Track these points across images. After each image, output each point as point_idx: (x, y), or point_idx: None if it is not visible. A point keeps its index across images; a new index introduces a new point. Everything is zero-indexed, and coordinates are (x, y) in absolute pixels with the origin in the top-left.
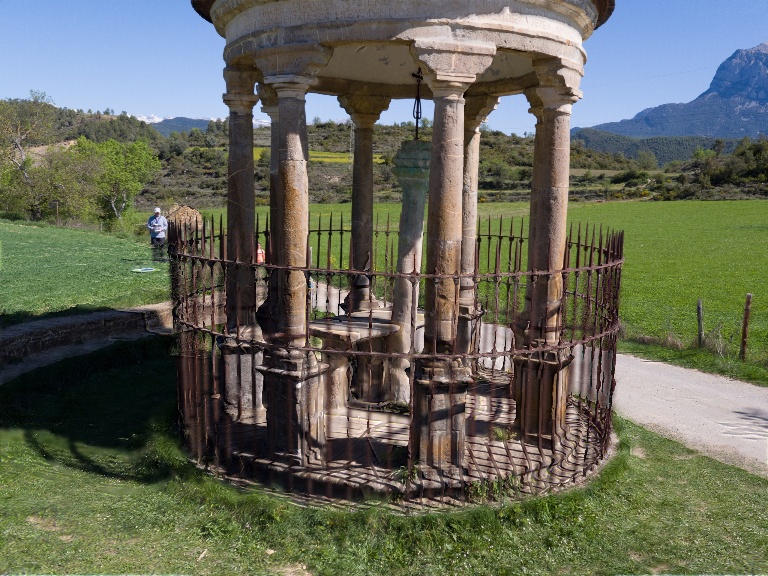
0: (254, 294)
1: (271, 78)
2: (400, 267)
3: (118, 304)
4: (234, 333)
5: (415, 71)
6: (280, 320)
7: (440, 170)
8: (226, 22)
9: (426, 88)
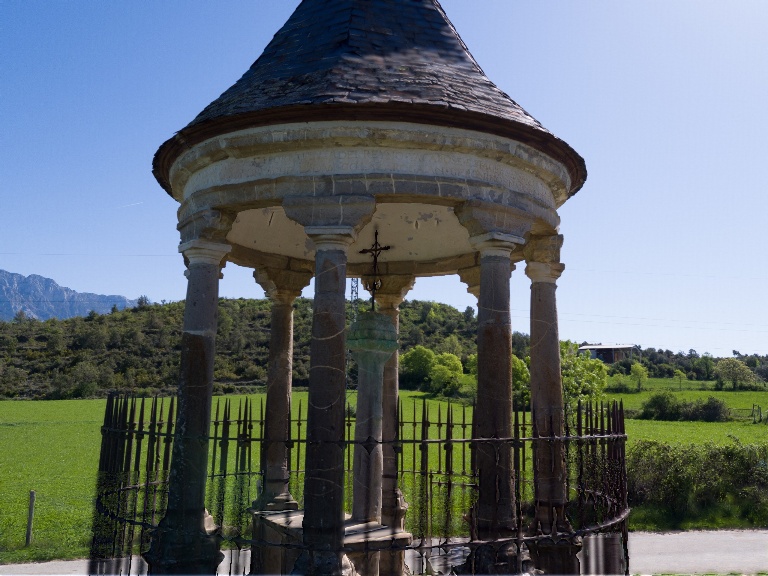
0: None
1: (504, 235)
2: (376, 451)
3: None
4: (348, 568)
5: (245, 232)
6: (506, 512)
7: (557, 345)
8: (377, 145)
9: (253, 253)
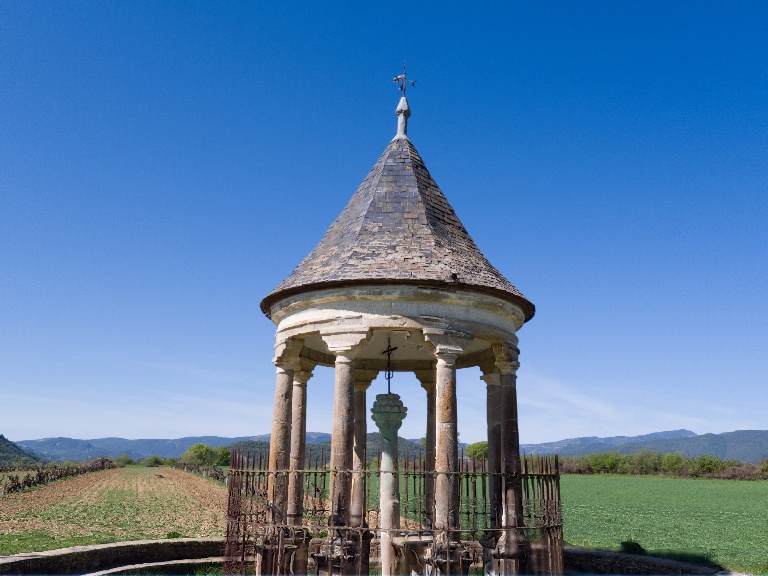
0: (429, 506)
1: None
2: None
3: (736, 567)
4: None
5: None
6: None
7: None
8: None
9: None
